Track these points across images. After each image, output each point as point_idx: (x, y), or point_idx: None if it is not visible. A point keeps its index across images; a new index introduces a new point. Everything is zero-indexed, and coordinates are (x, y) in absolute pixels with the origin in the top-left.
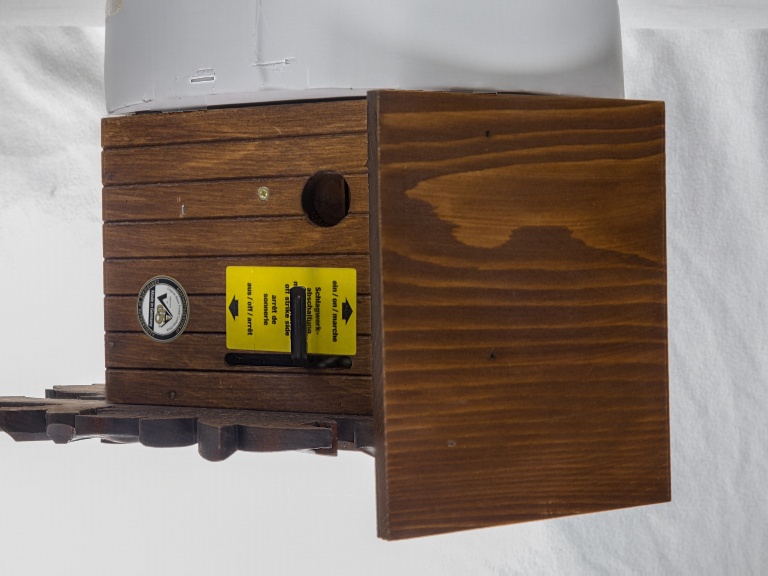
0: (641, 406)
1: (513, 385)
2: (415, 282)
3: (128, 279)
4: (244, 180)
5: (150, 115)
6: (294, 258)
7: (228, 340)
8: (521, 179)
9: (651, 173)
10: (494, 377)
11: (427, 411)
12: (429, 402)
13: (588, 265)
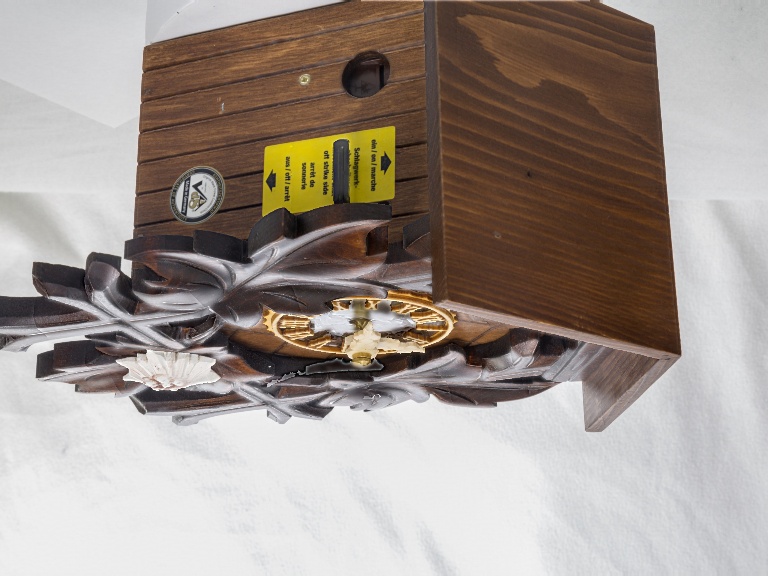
0: (651, 263)
1: (546, 205)
2: (465, 91)
3: (162, 176)
4: (285, 73)
5: (194, 36)
6: (333, 128)
7: (264, 209)
8: (546, 42)
9: (647, 77)
10: (531, 193)
11: (477, 200)
12: (478, 193)
13: (602, 130)
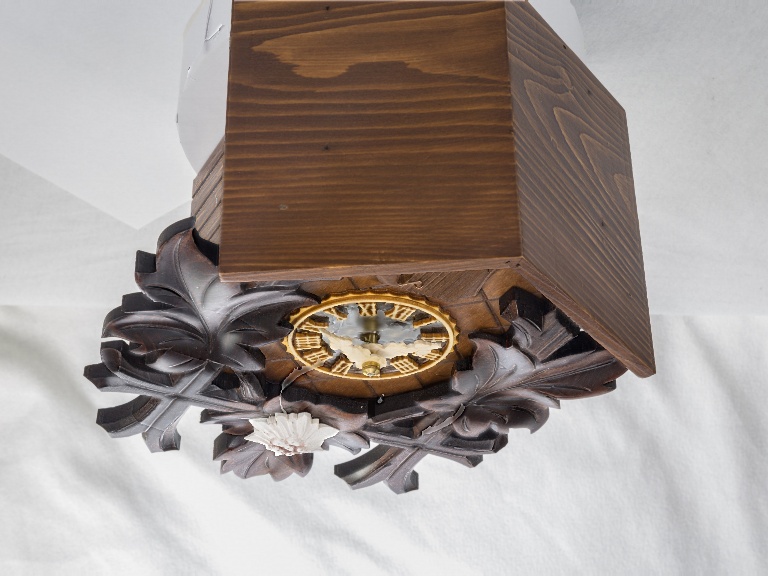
0: (484, 183)
1: (346, 168)
2: (256, 102)
3: None
4: None
5: None
6: None
7: None
8: (358, 34)
9: (490, 22)
10: (328, 162)
11: (262, 185)
12: (264, 179)
13: (425, 85)
